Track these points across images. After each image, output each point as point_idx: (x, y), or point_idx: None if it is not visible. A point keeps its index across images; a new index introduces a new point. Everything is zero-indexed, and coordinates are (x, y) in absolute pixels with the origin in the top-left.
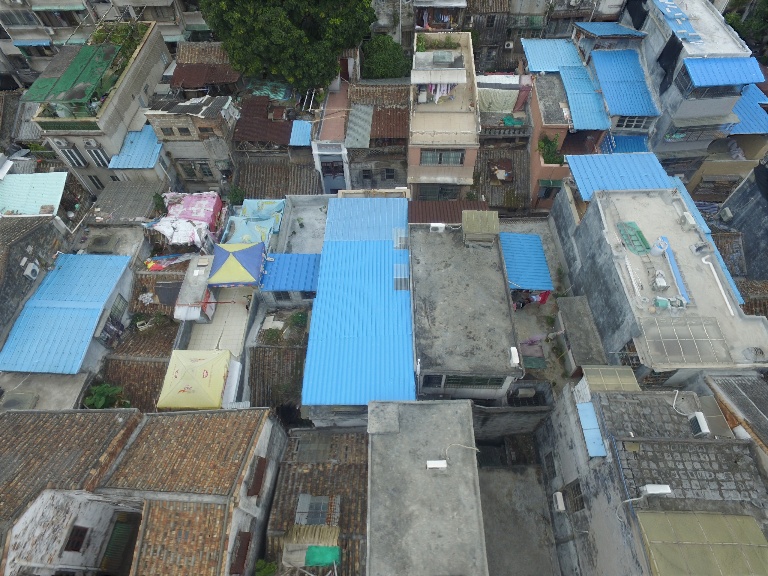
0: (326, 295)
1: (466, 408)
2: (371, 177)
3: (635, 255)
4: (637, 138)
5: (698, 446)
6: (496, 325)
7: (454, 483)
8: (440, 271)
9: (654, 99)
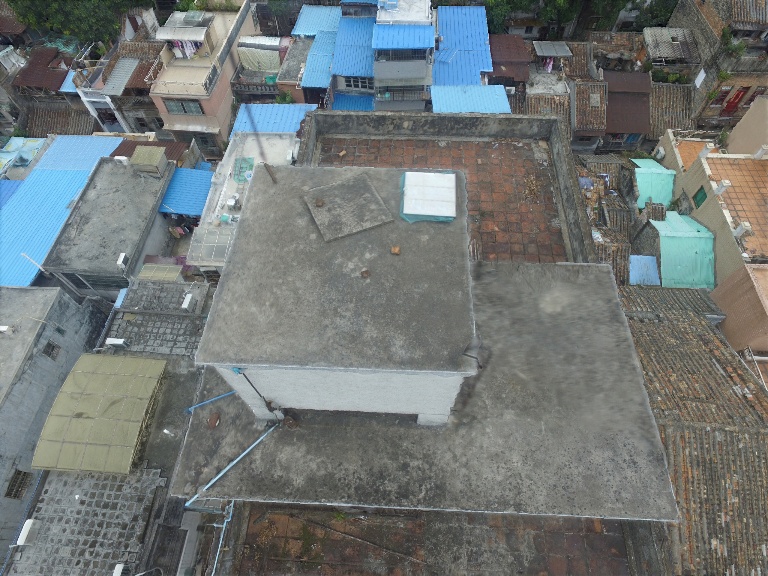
0: (8, 210)
1: (54, 293)
2: (146, 125)
3: (235, 183)
4: (367, 98)
5: (178, 318)
6: (128, 238)
7: (13, 344)
8: (108, 195)
9: None
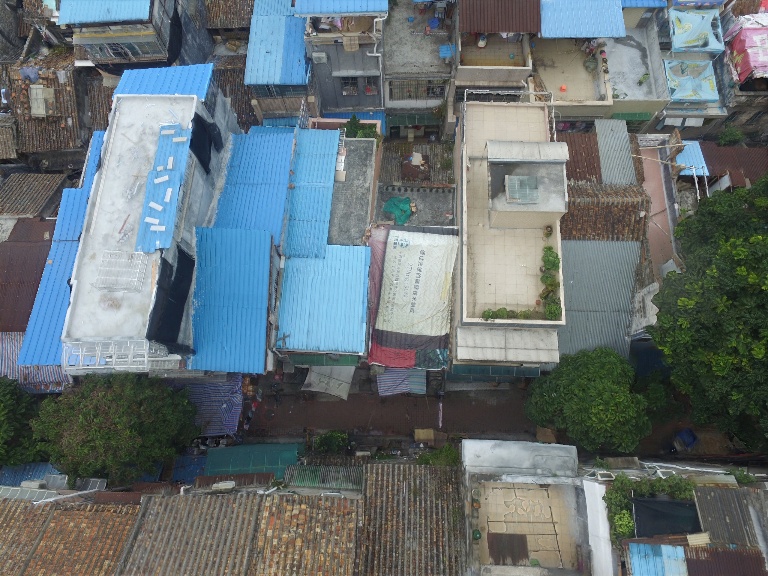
0: None
1: None
2: None
3: None
4: None
5: None
6: None
7: None
8: None
9: (229, 154)
